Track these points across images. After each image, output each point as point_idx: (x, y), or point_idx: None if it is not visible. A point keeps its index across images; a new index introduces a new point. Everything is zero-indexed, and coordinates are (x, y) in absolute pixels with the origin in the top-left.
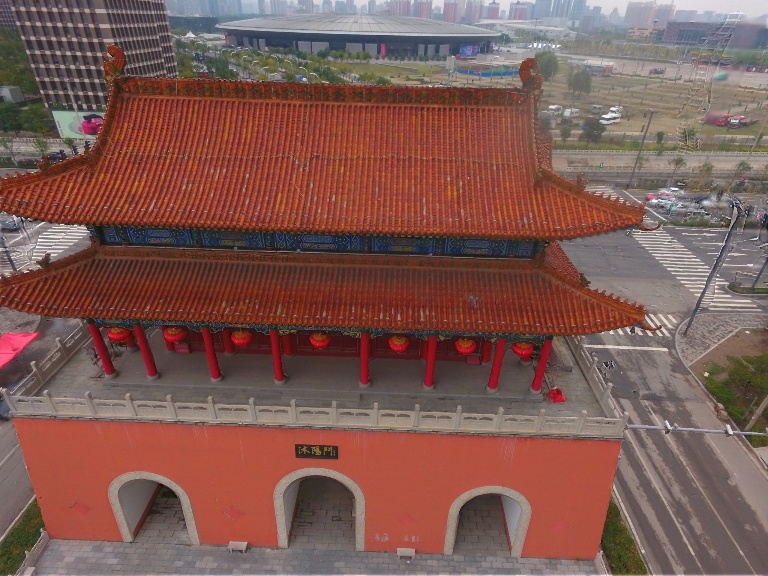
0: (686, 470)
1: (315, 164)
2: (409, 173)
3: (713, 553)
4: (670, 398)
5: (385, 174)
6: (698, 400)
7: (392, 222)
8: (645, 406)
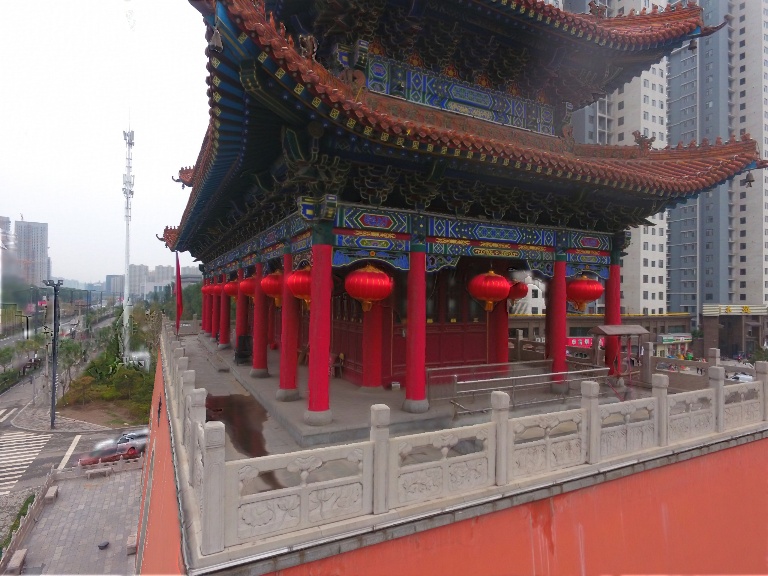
0: None
1: None
2: None
3: None
4: None
5: None
6: None
7: None
8: None
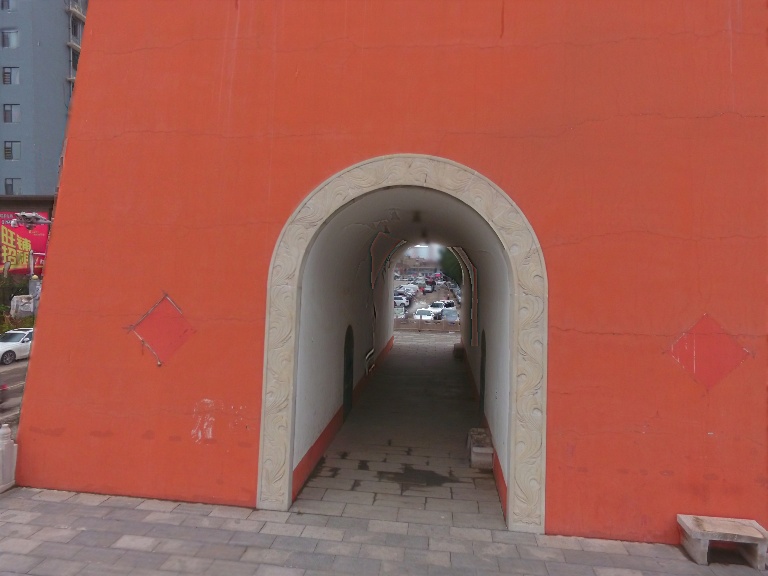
0: (7, 389)
1: None
2: None
3: None
4: None
5: None
6: None
7: None
8: None
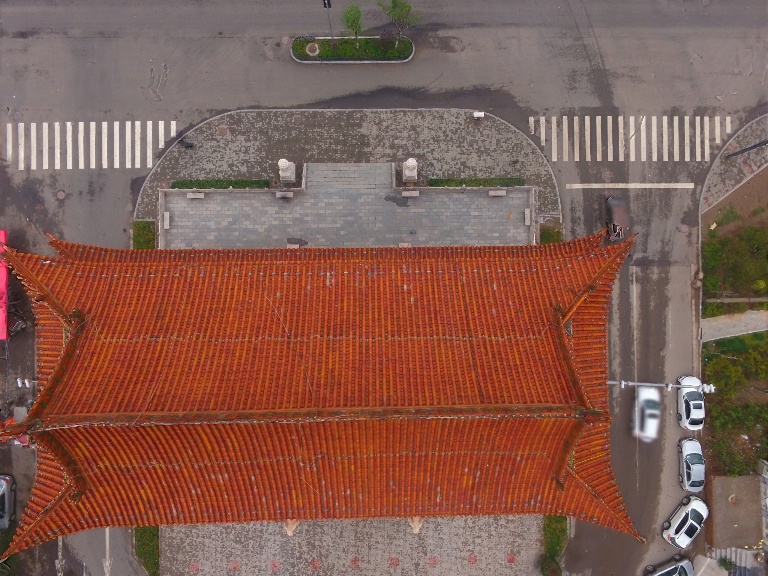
0: (633, 344)
1: (322, 464)
2: (425, 465)
3: (617, 410)
4: (660, 262)
5: (399, 468)
6: (685, 263)
7: (407, 510)
8: (631, 274)
